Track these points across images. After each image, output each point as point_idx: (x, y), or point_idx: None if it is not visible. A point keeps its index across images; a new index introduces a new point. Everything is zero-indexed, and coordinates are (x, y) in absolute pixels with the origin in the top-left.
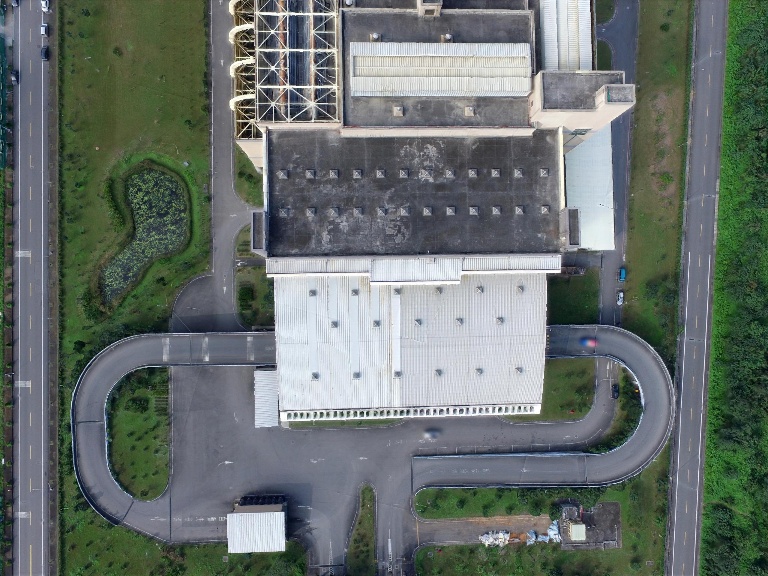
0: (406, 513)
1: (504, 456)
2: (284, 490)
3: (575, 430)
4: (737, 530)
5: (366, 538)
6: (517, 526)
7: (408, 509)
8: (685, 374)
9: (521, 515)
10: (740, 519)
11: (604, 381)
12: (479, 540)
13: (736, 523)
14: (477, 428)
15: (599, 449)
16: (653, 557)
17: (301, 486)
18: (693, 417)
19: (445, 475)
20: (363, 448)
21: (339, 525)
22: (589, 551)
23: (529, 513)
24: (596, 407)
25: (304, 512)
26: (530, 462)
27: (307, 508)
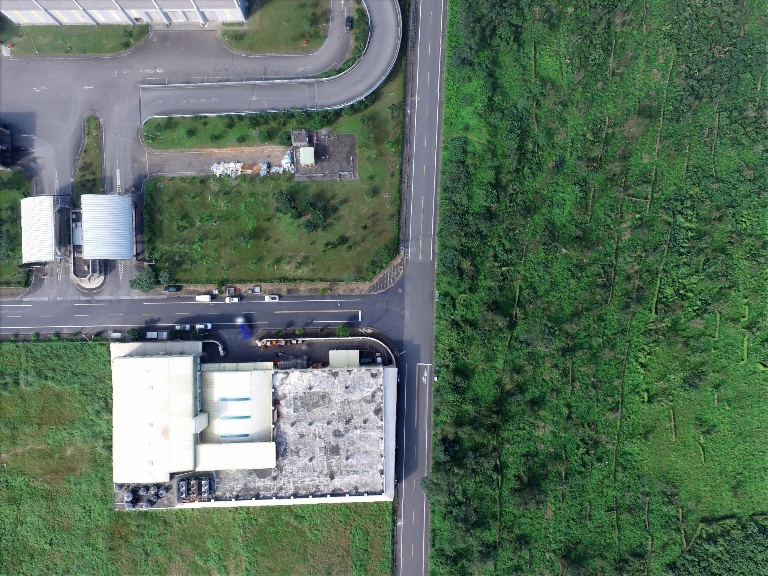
0: (135, 144)
1: (233, 84)
2: (7, 119)
3: (309, 62)
4: (470, 153)
5: (92, 167)
6: (250, 158)
7: (137, 140)
8: (423, 9)
9: (254, 147)
10: (475, 145)
11: (339, 14)
12: (211, 171)
13: (470, 148)
14: (207, 59)
15: (327, 72)
16: (391, 189)
17: (24, 115)
18: (431, 51)
19: (174, 105)
20: (88, 77)
21: (65, 154)
22: (325, 182)
23: (262, 145)
24: (331, 40)
25: (28, 141)
26: (260, 90)
27: (31, 137)
